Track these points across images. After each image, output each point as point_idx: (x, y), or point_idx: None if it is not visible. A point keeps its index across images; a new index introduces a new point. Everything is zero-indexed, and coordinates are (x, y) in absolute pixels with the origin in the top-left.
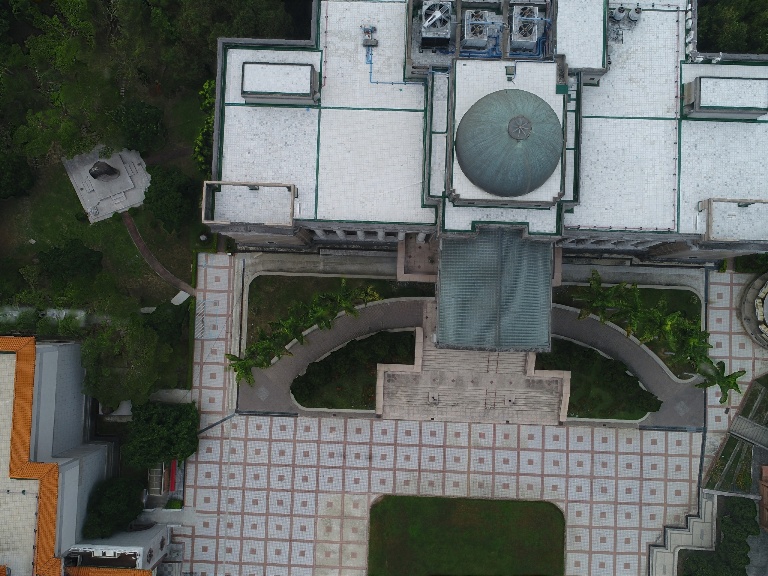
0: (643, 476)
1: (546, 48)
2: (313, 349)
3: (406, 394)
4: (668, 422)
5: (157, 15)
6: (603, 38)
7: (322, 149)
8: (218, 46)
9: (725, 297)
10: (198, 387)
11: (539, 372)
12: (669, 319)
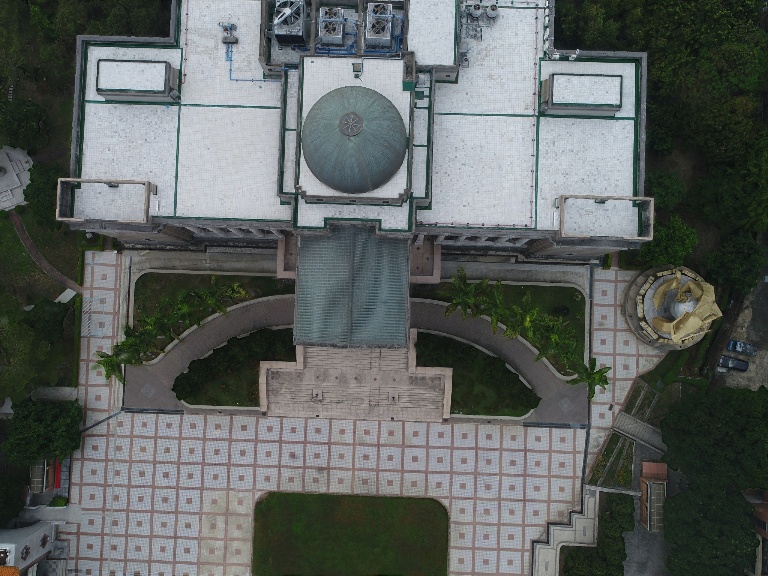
0: (527, 473)
1: (402, 45)
2: (198, 346)
3: (290, 391)
4: (552, 419)
5: (36, 13)
6: (454, 35)
7: (182, 146)
8: (77, 43)
9: (610, 294)
10: (84, 385)
11: (421, 369)
12: (529, 315)
